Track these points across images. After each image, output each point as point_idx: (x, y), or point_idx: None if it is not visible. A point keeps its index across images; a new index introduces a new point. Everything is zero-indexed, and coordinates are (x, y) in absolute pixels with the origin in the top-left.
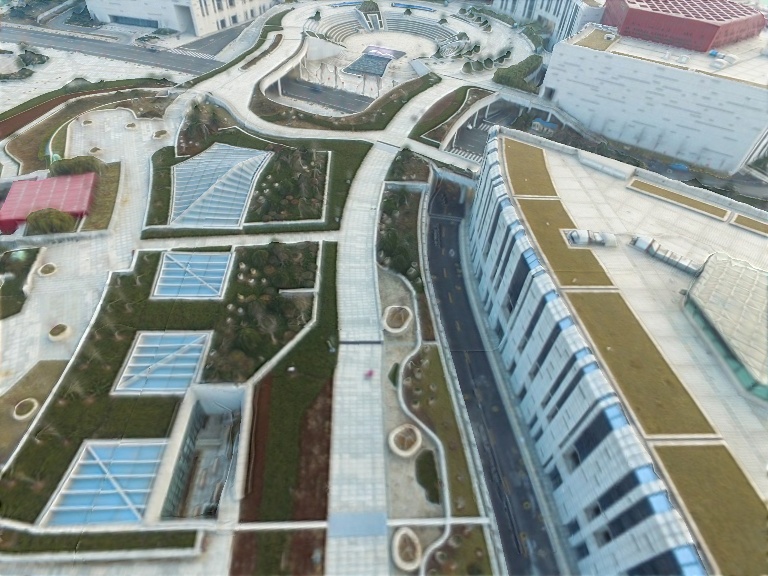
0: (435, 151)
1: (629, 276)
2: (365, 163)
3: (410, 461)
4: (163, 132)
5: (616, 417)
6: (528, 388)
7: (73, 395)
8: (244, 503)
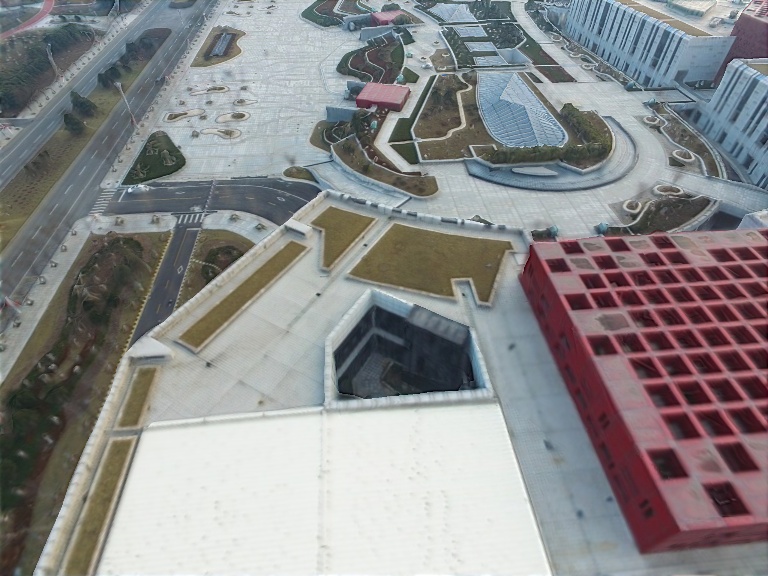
0: (542, 3)
1: (646, 4)
2: (512, 7)
3: (579, 59)
4: (408, 2)
5: (647, 18)
6: (612, 50)
7: (461, 50)
8: (533, 63)
